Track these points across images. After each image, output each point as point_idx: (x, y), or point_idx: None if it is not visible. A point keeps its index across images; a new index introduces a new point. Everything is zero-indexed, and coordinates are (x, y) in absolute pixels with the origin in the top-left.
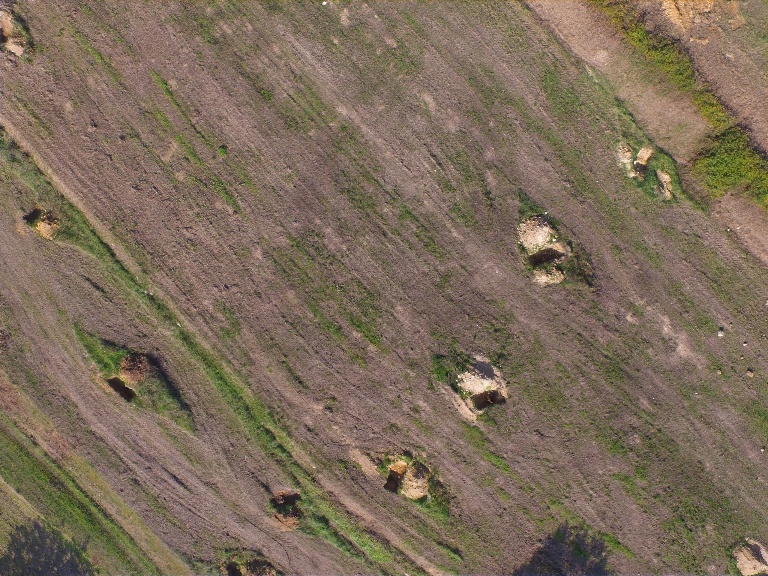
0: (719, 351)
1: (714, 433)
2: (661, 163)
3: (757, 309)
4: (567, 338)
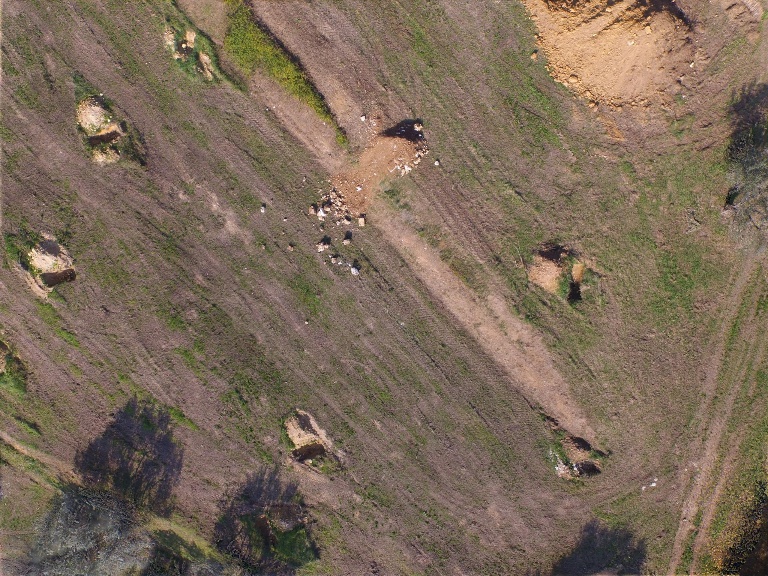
0: (263, 227)
1: (263, 307)
2: (202, 45)
3: (296, 186)
4: (127, 216)
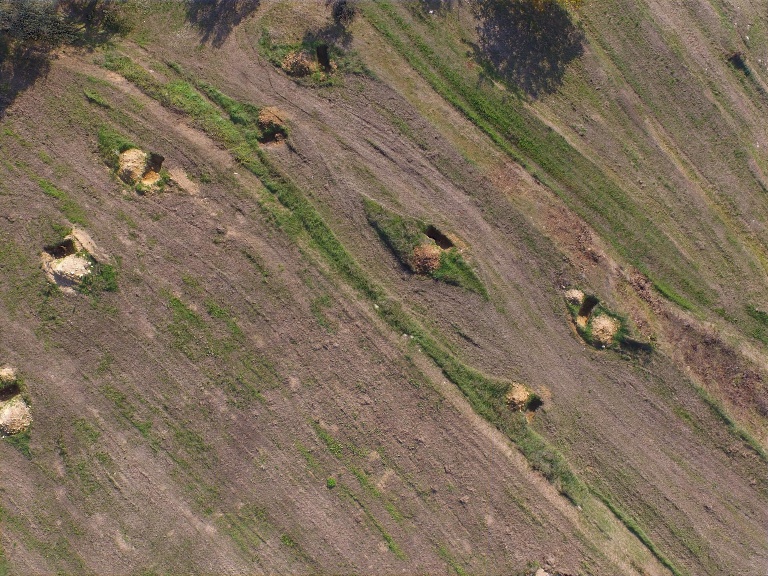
0: None
1: None
2: None
3: None
4: None
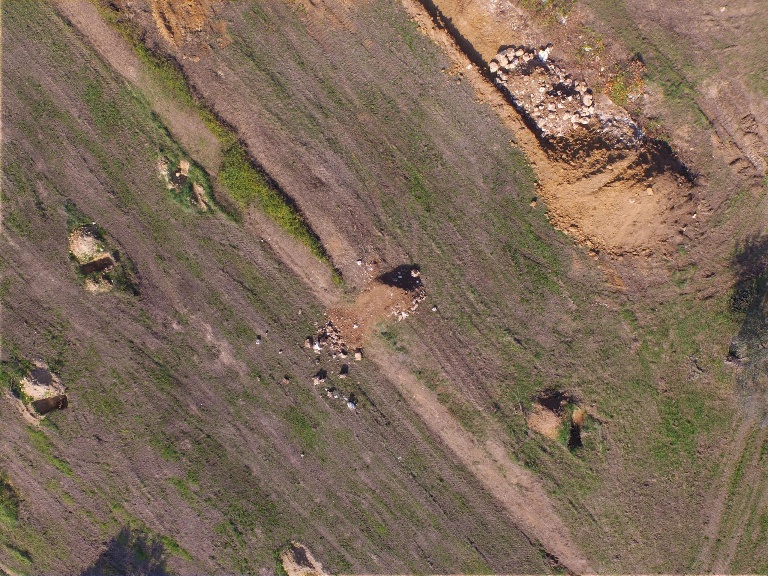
0: (258, 359)
1: (258, 438)
2: (196, 176)
3: (291, 318)
4: (120, 345)
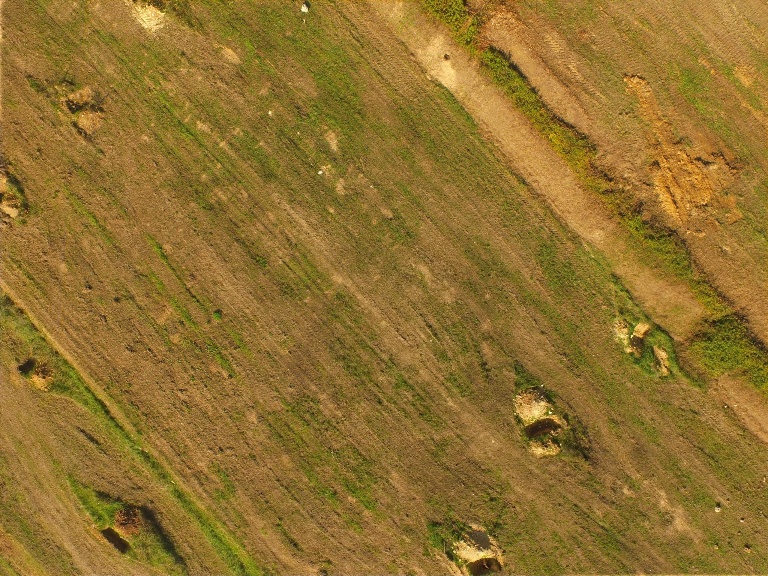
0: (716, 526)
1: None
2: (658, 340)
3: (754, 485)
4: (563, 509)
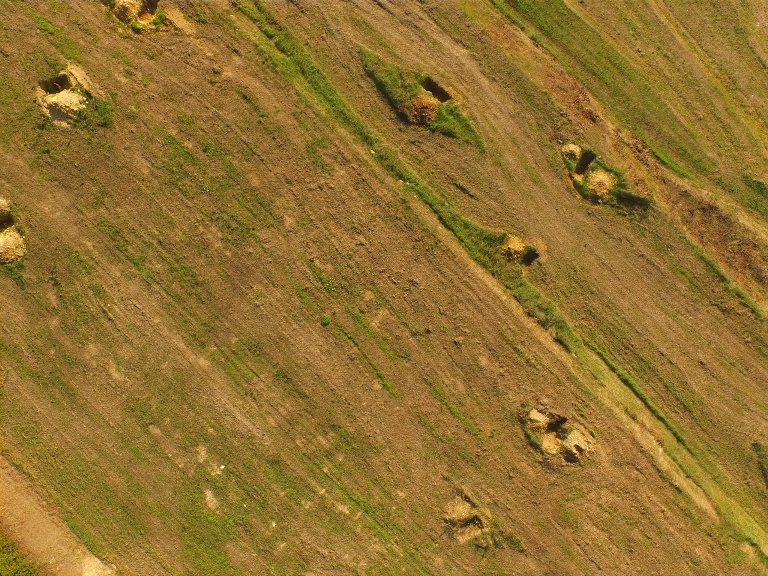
0: None
1: None
2: None
3: None
4: None
